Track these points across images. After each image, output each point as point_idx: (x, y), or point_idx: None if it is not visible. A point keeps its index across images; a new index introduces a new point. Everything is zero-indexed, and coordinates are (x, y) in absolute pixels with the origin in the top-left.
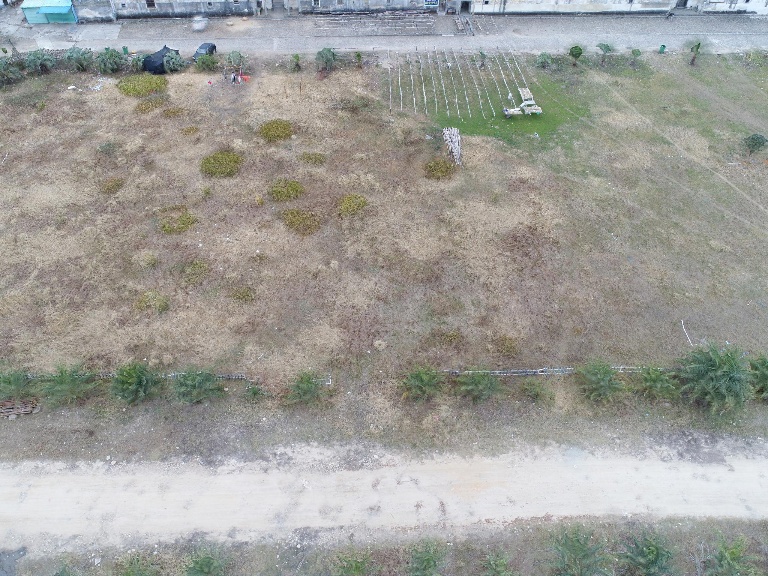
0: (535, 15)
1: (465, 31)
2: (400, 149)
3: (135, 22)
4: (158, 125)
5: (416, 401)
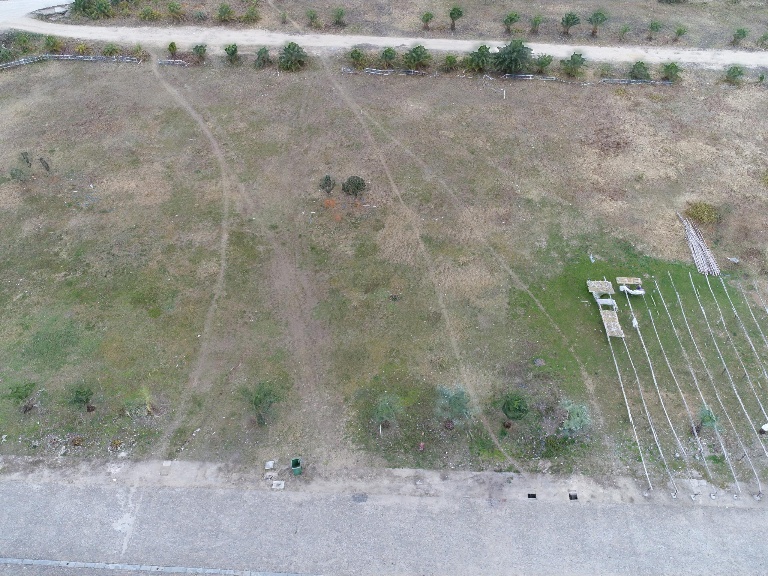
0: None
1: None
2: (763, 245)
3: None
4: None
5: None
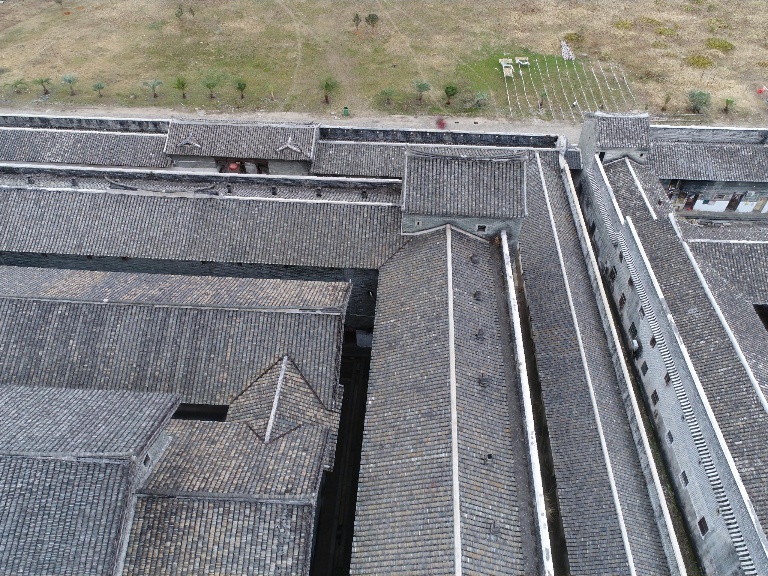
0: None
1: None
2: None
3: None
4: None
5: None
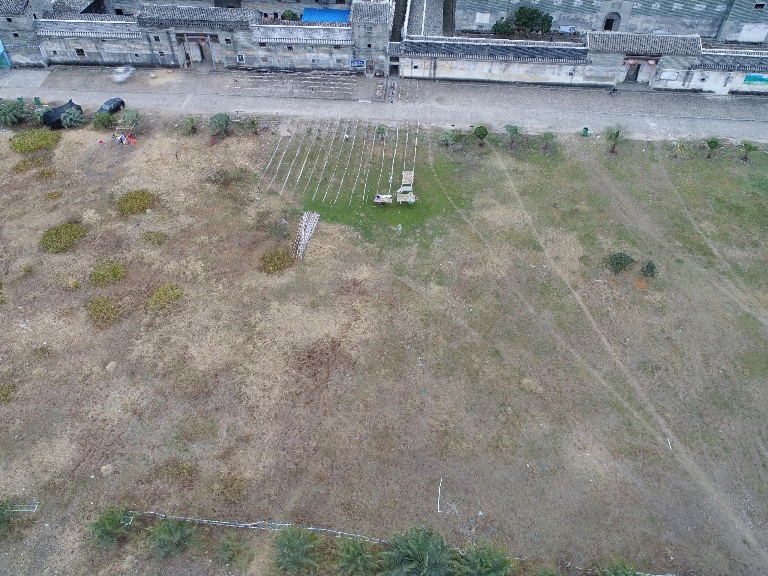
0: (468, 82)
1: (385, 97)
2: (248, 233)
3: (66, 69)
4: (26, 187)
5: (107, 545)
